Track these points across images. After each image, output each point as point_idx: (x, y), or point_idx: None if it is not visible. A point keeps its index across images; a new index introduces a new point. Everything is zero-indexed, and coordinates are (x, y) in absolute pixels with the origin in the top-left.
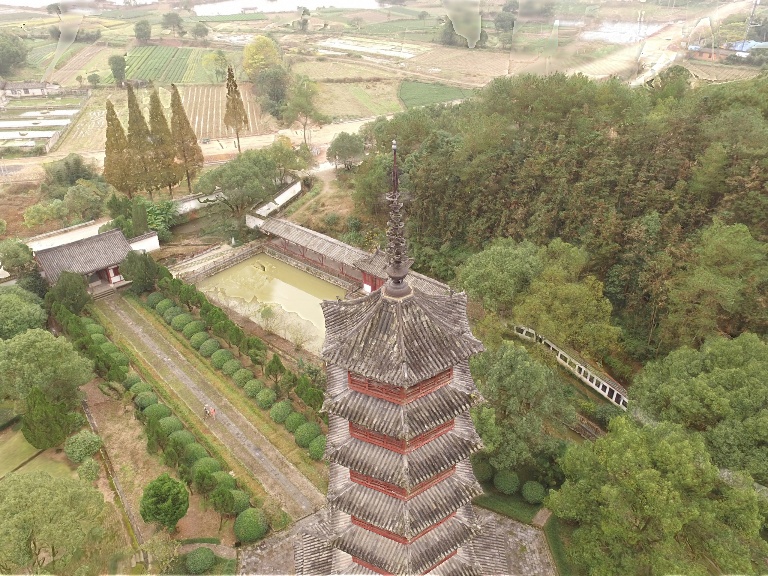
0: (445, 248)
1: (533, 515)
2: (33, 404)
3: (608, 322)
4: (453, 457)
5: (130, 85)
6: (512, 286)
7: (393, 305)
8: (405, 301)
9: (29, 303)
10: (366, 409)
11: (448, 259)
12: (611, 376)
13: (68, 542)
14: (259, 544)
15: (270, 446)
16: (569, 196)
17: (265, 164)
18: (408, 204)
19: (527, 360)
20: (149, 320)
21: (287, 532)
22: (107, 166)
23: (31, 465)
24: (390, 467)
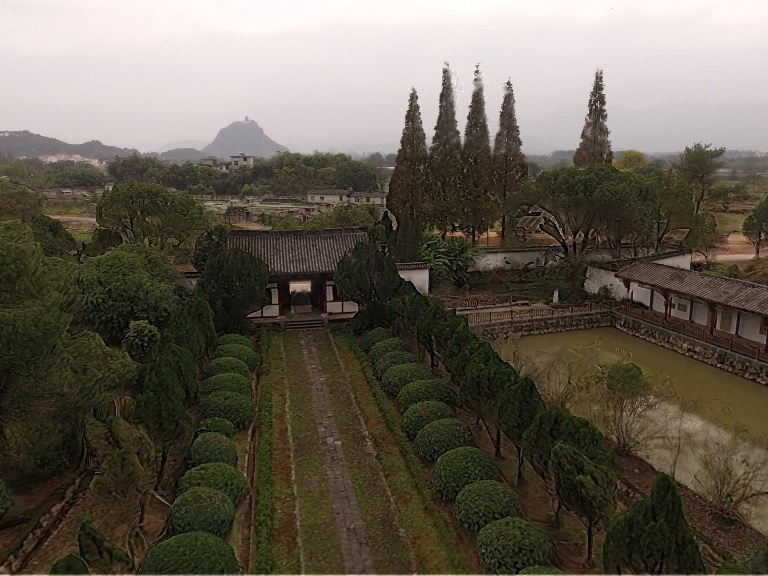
0: None
1: None
2: None
3: None
4: None
5: (448, 73)
6: None
7: None
8: None
9: (161, 281)
10: None
11: None
12: None
13: None
14: None
15: None
16: None
17: (638, 190)
18: None
19: None
20: (348, 368)
21: None
22: (392, 184)
23: None
24: None
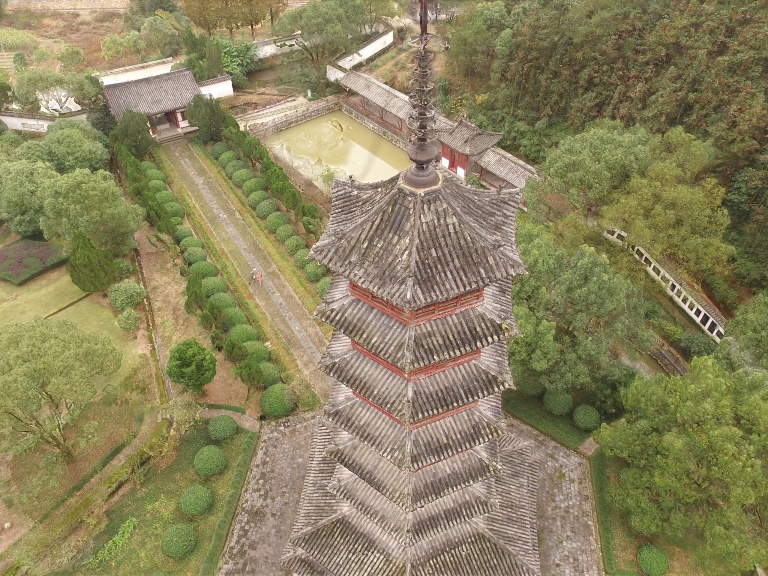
0: (541, 125)
1: (581, 441)
2: (76, 247)
3: (720, 238)
4: (472, 393)
5: None
6: (607, 180)
7: (411, 198)
8: (428, 194)
9: (92, 140)
10: (366, 323)
11: (542, 138)
12: (710, 299)
13: (76, 398)
14: (283, 421)
15: (311, 322)
16: (706, 73)
17: (353, 7)
18: (506, 68)
19: (606, 272)
20: (211, 171)
21: (313, 413)
22: None
23: (79, 306)
24: (391, 393)
